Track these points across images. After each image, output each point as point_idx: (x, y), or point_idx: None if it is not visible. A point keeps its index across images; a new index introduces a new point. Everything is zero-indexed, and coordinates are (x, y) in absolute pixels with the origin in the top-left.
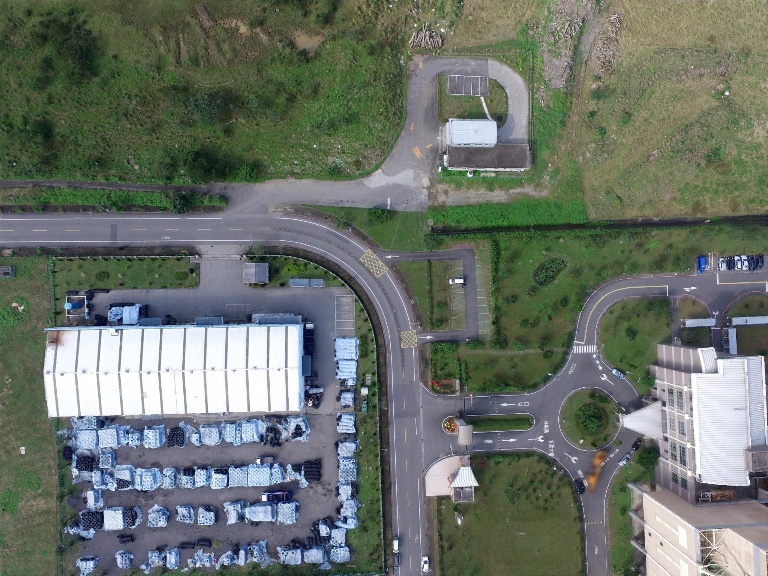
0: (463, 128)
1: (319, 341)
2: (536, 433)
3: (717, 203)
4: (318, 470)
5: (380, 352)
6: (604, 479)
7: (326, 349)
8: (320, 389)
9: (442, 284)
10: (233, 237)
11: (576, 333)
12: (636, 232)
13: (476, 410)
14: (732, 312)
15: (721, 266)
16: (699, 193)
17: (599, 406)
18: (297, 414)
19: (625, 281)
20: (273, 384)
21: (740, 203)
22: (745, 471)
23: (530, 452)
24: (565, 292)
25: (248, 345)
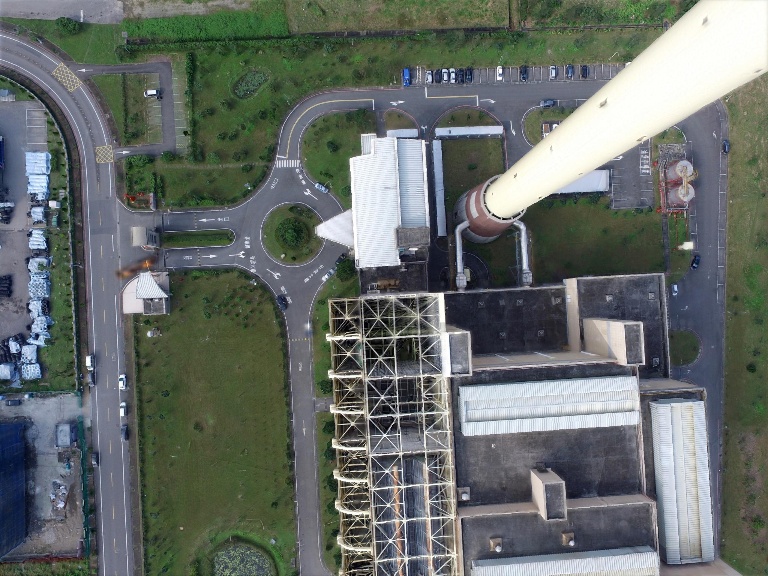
0: None
1: (10, 156)
2: (237, 249)
3: (424, 15)
4: (7, 286)
5: (74, 167)
6: (308, 295)
7: (17, 164)
8: (7, 202)
9: (138, 98)
10: None
11: (278, 147)
12: (337, 43)
13: (175, 226)
14: (441, 126)
15: (427, 78)
16: (405, 5)
17: (301, 220)
18: None
19: (329, 94)
20: None
21: (448, 15)
22: (395, 251)
23: (230, 268)
24: (266, 105)
25: None
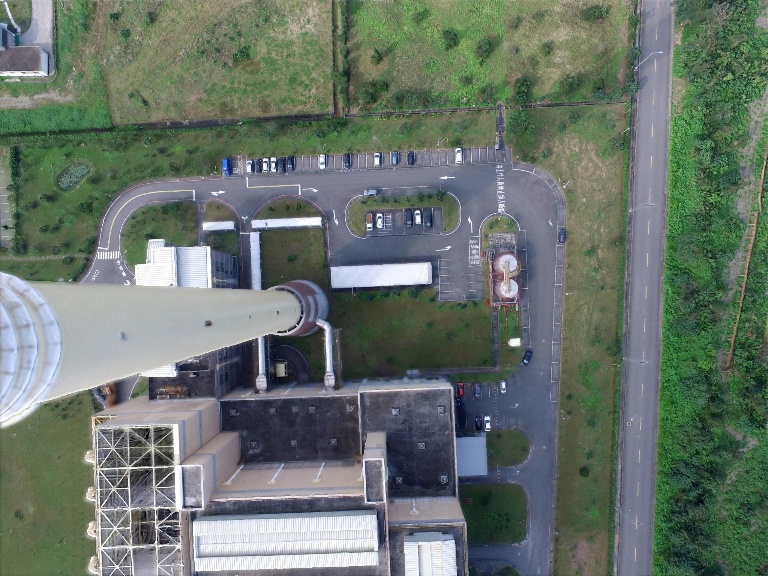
0: None
1: None
2: None
3: (246, 104)
4: None
5: None
6: (127, 387)
7: None
8: None
9: None
10: None
11: (100, 239)
12: (156, 134)
13: None
14: (261, 216)
15: None
16: (226, 94)
17: None
18: None
19: (150, 186)
20: None
21: (270, 103)
22: None
23: None
24: None
25: None
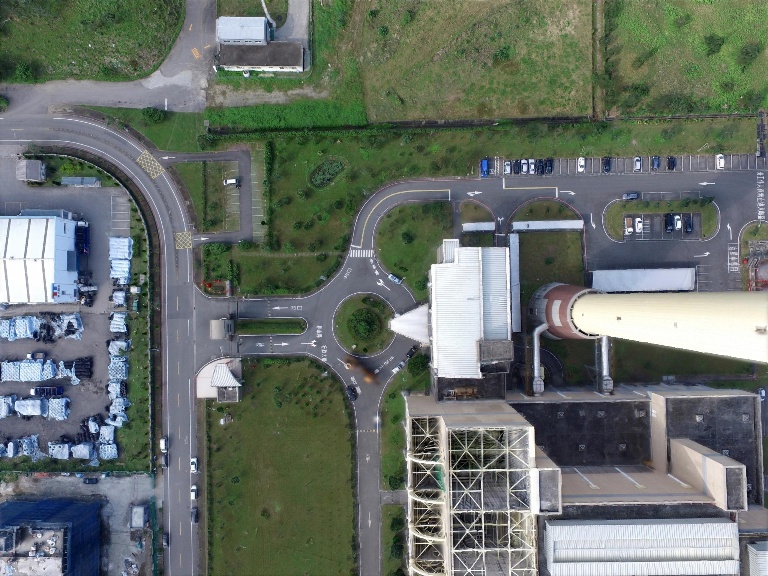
0: (230, 23)
1: (94, 240)
2: (309, 337)
3: (504, 104)
4: (88, 367)
5: (154, 253)
6: (378, 387)
7: (101, 248)
8: (91, 287)
9: (217, 185)
10: (13, 137)
11: (353, 237)
12: (415, 133)
13: (249, 313)
14: (518, 218)
15: (505, 169)
16: (485, 94)
17: (373, 311)
18: (71, 312)
19: (405, 184)
20: (31, 275)
21: (529, 105)
22: (477, 363)
23: (302, 356)
24: (342, 195)
25: (8, 236)
